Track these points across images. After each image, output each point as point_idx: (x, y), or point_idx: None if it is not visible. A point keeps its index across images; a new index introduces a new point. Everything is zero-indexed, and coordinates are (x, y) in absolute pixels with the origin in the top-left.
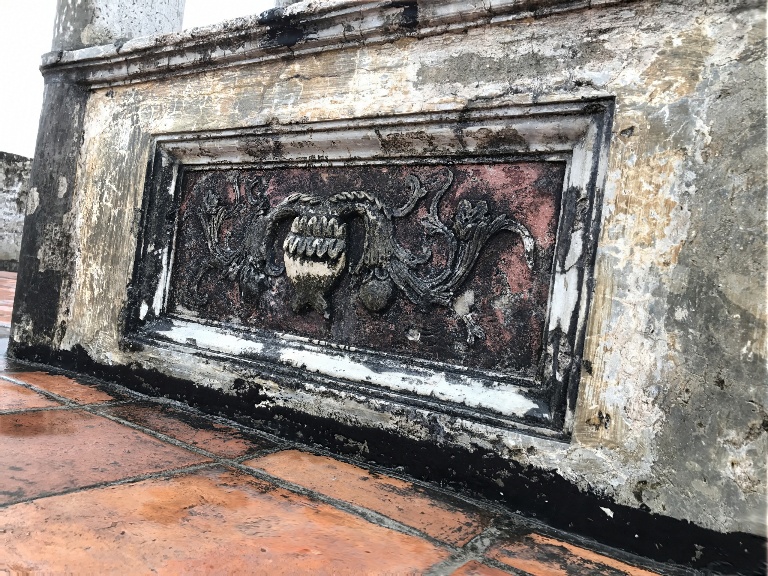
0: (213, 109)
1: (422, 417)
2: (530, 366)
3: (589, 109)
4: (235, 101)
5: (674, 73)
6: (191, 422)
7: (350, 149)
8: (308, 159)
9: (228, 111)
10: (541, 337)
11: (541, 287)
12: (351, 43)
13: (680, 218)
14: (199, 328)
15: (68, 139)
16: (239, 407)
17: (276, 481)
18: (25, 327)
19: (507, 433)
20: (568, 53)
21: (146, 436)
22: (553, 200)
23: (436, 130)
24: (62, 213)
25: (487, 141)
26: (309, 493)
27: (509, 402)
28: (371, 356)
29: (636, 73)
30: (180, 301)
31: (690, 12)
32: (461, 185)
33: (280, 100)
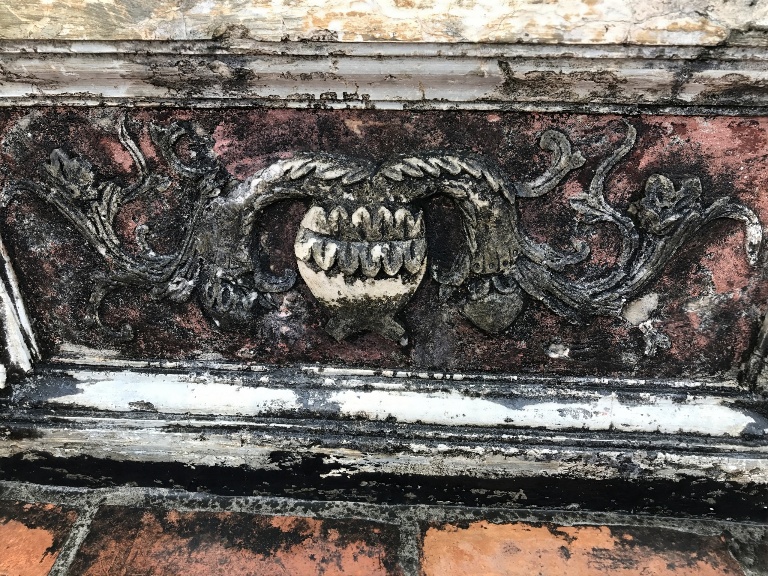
0: None
1: (610, 460)
2: (729, 369)
3: None
4: None
5: None
6: (243, 540)
7: (426, 86)
8: (318, 98)
9: None
10: (751, 340)
11: (761, 284)
12: None
13: None
14: (140, 379)
15: None
16: (291, 482)
17: None
18: None
19: (727, 460)
20: None
21: None
22: None
23: (639, 71)
24: None
25: (726, 89)
26: None
27: (716, 420)
28: (492, 383)
29: None
30: (64, 338)
31: None
32: (650, 149)
33: None
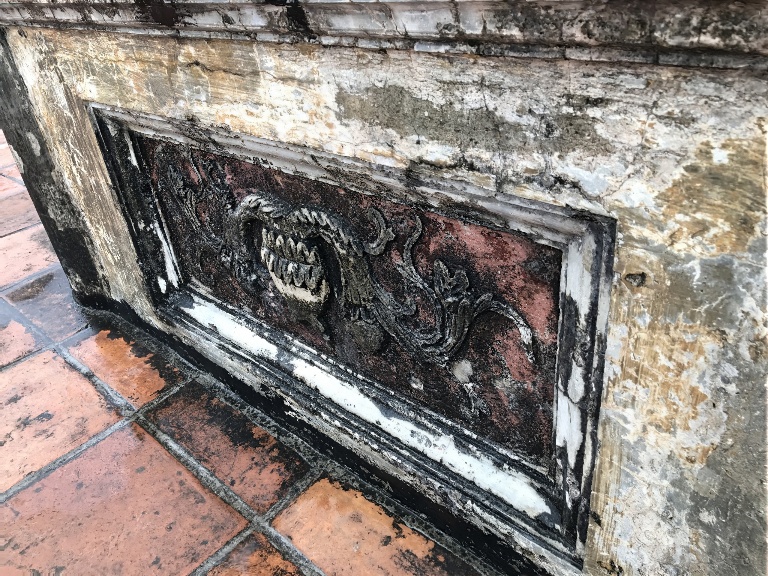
0: (127, 84)
1: (434, 487)
2: (542, 456)
3: (580, 218)
4: (145, 79)
5: (712, 210)
6: (232, 431)
7: (293, 163)
8: None
9: (143, 91)
10: (551, 435)
11: (546, 384)
12: (240, 35)
13: (711, 416)
14: (217, 311)
15: (11, 88)
16: (272, 409)
17: (300, 563)
18: (75, 279)
19: (518, 535)
20: (539, 126)
21: (189, 479)
22: (550, 291)
23: (382, 178)
24: (48, 171)
25: None
26: None
27: (520, 496)
28: (379, 391)
29: (648, 192)
30: (192, 274)
31: (747, 104)
32: (433, 238)
33: (190, 93)
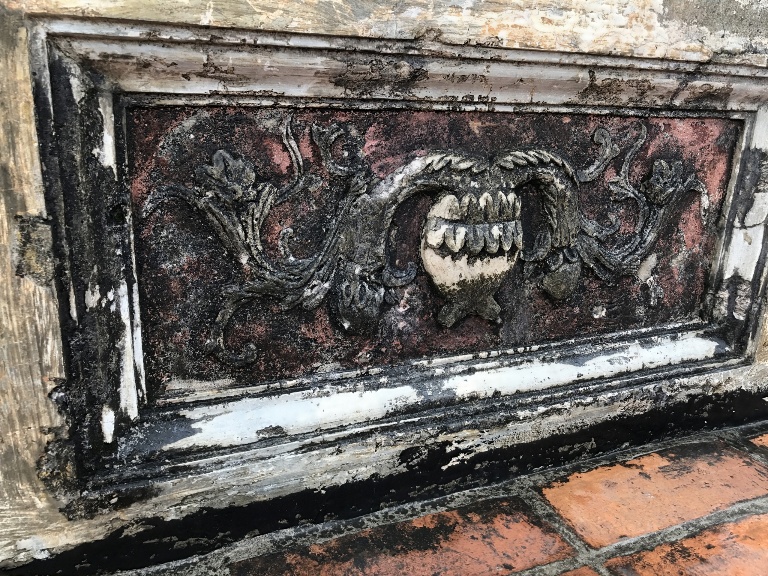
0: None
1: (650, 392)
2: (694, 310)
3: None
4: None
5: None
6: (403, 545)
7: (536, 91)
8: (461, 100)
9: None
10: (705, 283)
11: (708, 240)
12: None
13: None
14: (263, 405)
15: None
16: (416, 482)
17: (660, 539)
18: None
19: (714, 375)
20: None
21: None
22: (726, 157)
23: (663, 80)
24: None
25: (698, 96)
26: (695, 527)
27: (699, 348)
28: (559, 349)
29: None
30: (175, 373)
31: None
32: (653, 142)
33: None
